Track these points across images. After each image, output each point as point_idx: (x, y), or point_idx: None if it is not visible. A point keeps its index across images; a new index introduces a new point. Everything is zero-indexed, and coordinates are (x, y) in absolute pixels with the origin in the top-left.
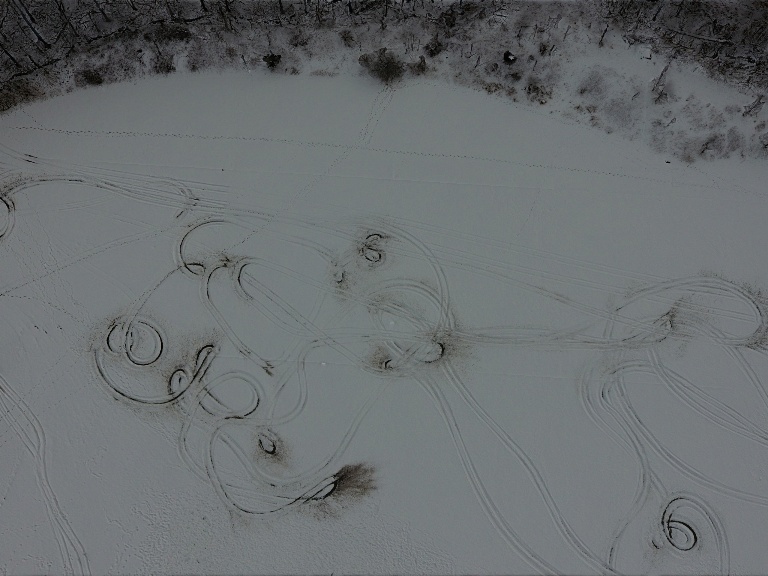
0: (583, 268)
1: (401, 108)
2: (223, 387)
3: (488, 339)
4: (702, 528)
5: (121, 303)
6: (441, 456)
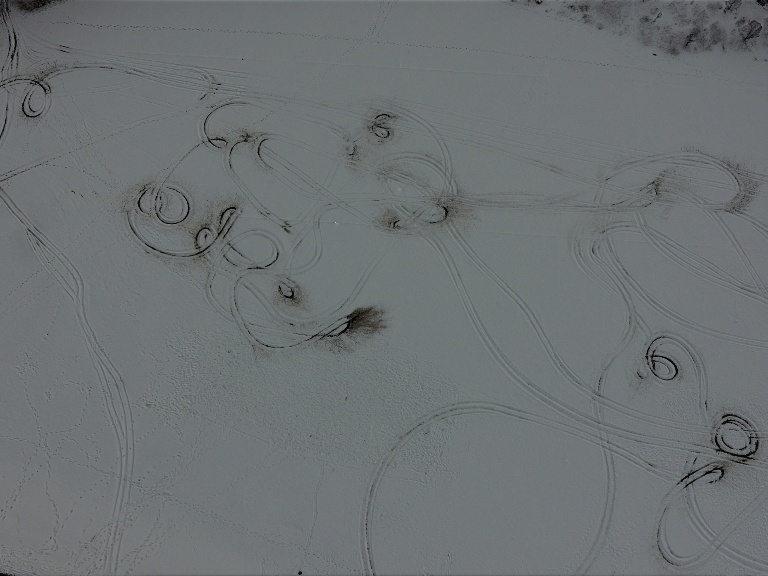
0: (575, 144)
1: (407, 7)
2: (245, 242)
3: (488, 203)
4: (683, 362)
5: (150, 172)
6: (445, 301)
